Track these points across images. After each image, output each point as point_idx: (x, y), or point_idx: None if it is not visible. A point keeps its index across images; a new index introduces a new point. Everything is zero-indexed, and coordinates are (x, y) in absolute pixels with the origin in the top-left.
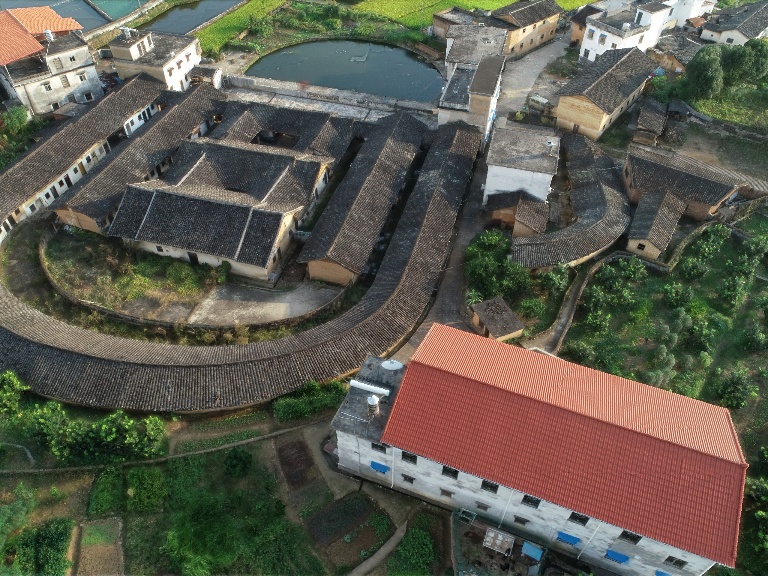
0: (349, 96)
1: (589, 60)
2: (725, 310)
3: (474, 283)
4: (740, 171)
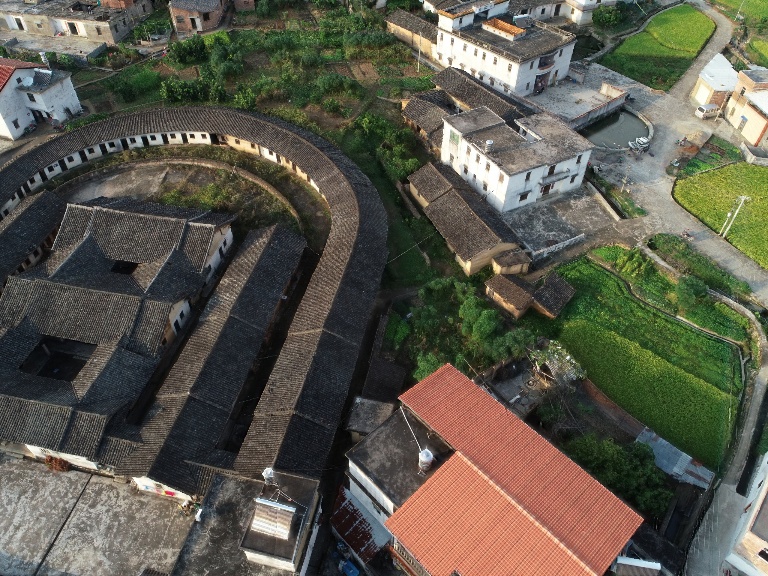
0: None
1: None
2: None
3: None
4: None
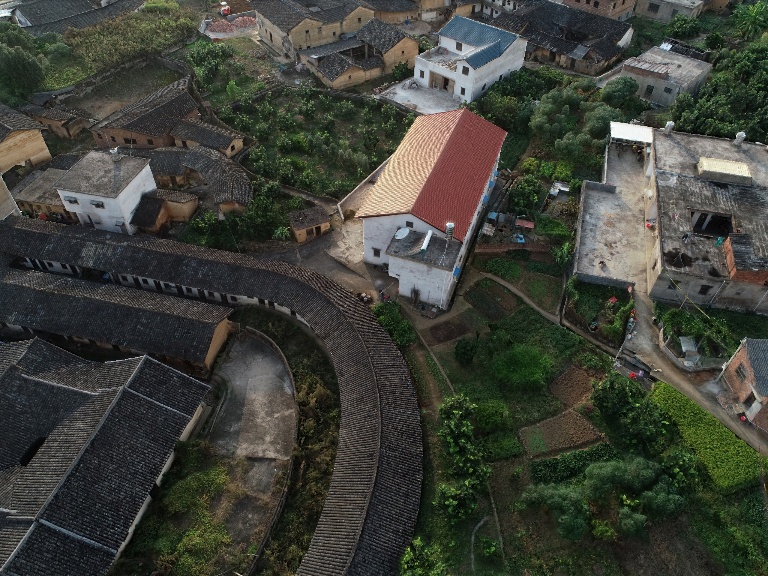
0: None
1: None
2: (295, 132)
3: (261, 234)
4: (141, 96)
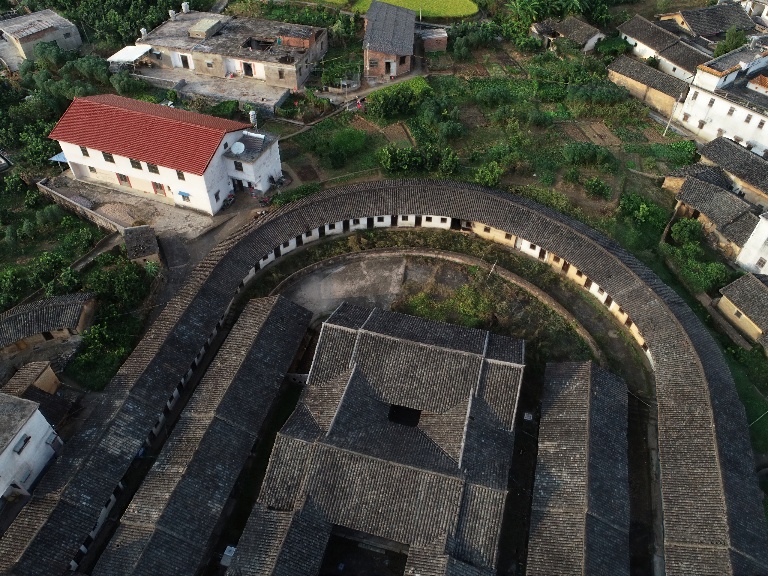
0: None
1: None
2: None
3: None
4: None
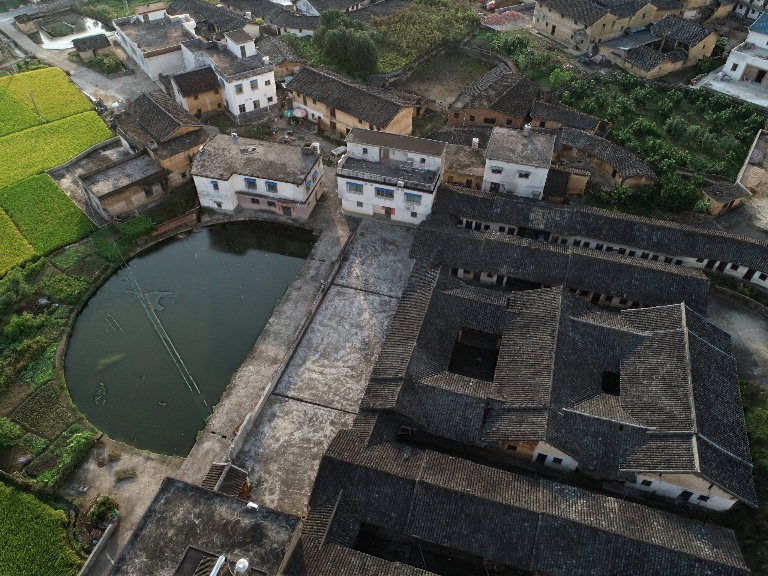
0: (296, 304)
1: (248, 112)
2: (632, 117)
3: (680, 206)
4: (457, 81)
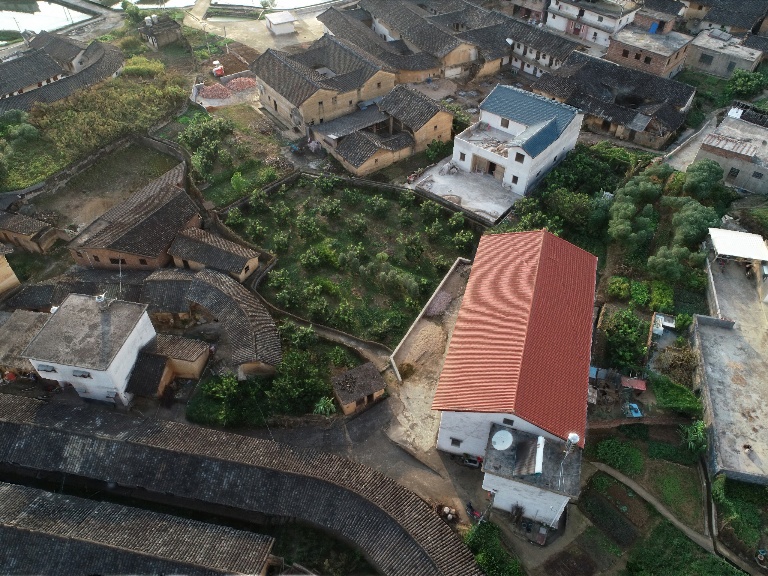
0: None
1: None
2: (319, 238)
3: (297, 407)
4: (126, 189)
